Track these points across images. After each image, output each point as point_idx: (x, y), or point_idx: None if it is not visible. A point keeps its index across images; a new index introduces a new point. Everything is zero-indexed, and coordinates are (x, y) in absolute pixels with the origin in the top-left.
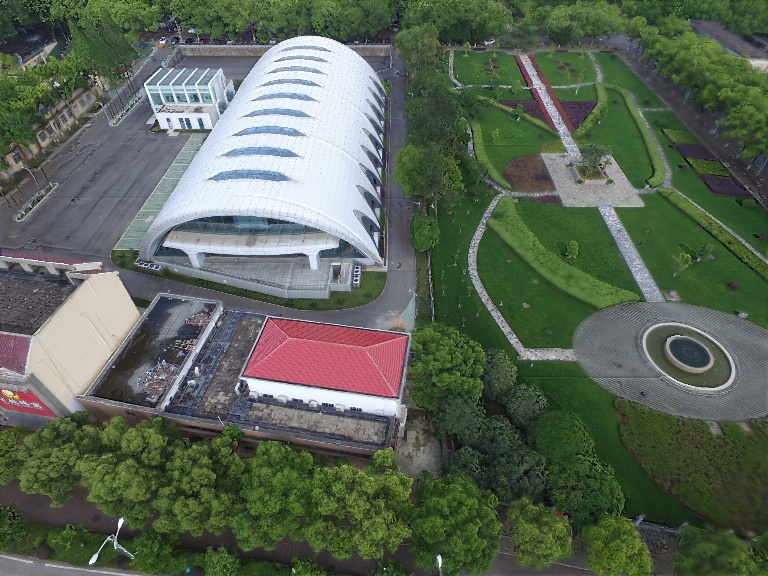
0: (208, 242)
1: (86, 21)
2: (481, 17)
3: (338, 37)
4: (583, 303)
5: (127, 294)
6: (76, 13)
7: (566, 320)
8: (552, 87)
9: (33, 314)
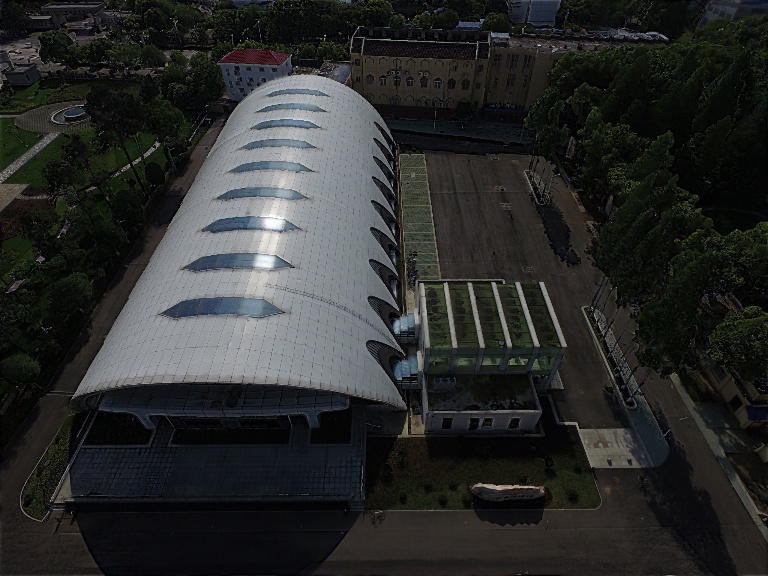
0: None
1: None
2: None
3: None
4: None
5: (351, 65)
6: None
7: None
8: None
9: None
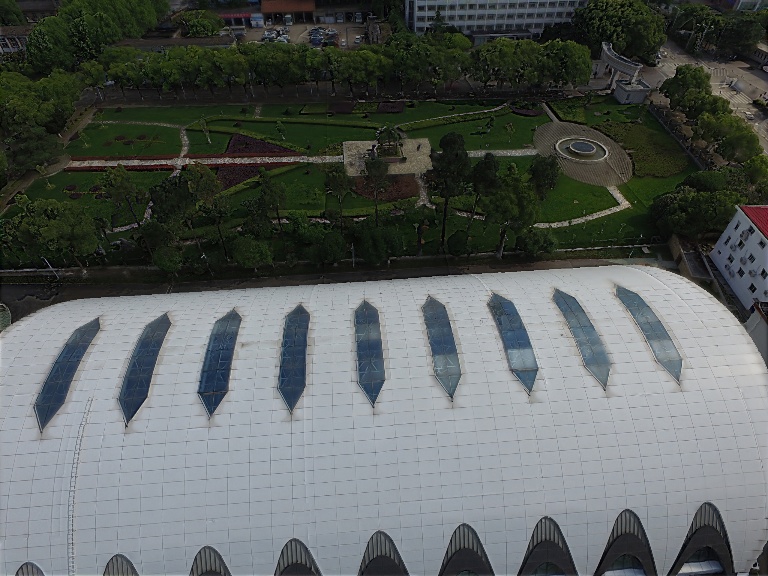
0: None
1: None
2: None
3: None
4: (559, 178)
5: None
6: None
7: (580, 186)
8: None
9: None
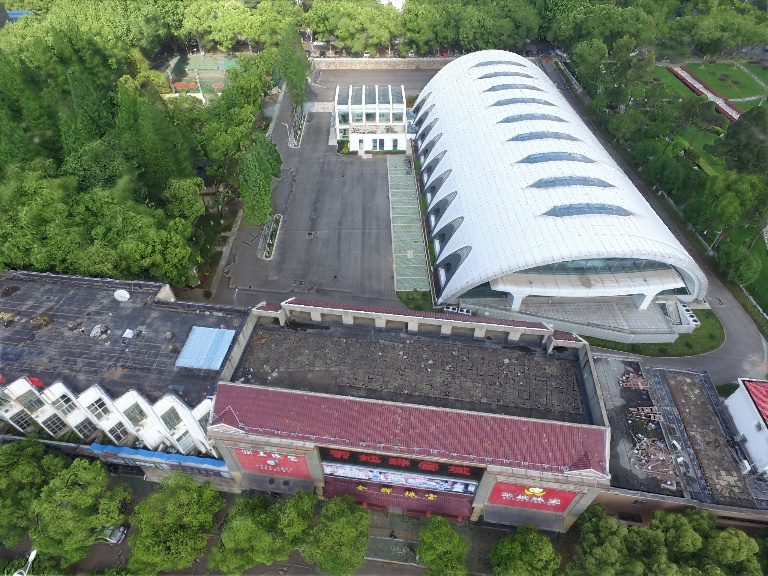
0: (541, 284)
1: (286, 37)
2: (634, 28)
3: (484, 49)
4: None
5: None
6: (209, 26)
7: None
8: (728, 100)
9: (535, 392)
